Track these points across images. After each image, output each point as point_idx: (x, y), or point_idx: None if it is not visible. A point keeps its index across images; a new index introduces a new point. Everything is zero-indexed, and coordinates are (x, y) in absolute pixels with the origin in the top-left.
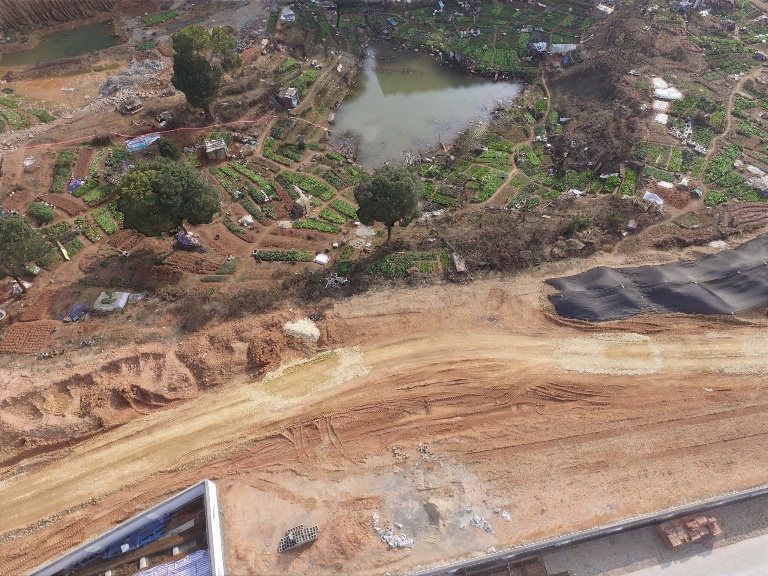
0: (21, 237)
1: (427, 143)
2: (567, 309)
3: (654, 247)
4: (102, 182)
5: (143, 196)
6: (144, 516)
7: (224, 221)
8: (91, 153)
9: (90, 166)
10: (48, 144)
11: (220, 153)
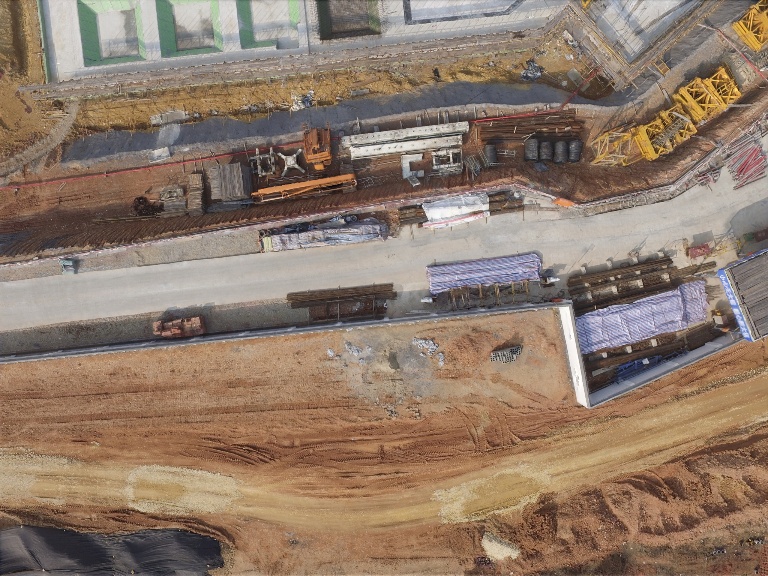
0: None
1: None
2: (208, 548)
3: None
4: None
5: None
6: (637, 385)
7: None
8: None
9: None
10: None
11: None
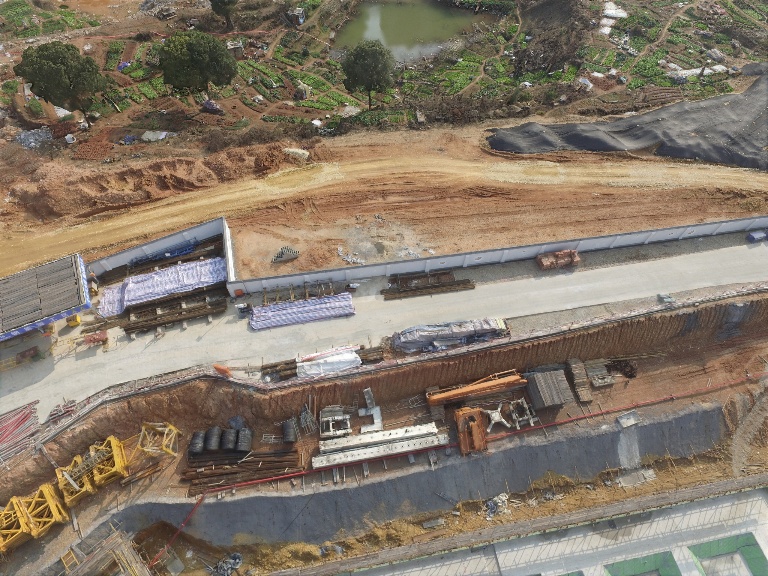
0: (93, 69)
1: (412, 57)
2: (498, 144)
3: (578, 114)
4: (144, 65)
5: (180, 52)
6: (181, 233)
7: (240, 98)
8: (135, 45)
9: (135, 54)
10: (101, 37)
11: (238, 52)
